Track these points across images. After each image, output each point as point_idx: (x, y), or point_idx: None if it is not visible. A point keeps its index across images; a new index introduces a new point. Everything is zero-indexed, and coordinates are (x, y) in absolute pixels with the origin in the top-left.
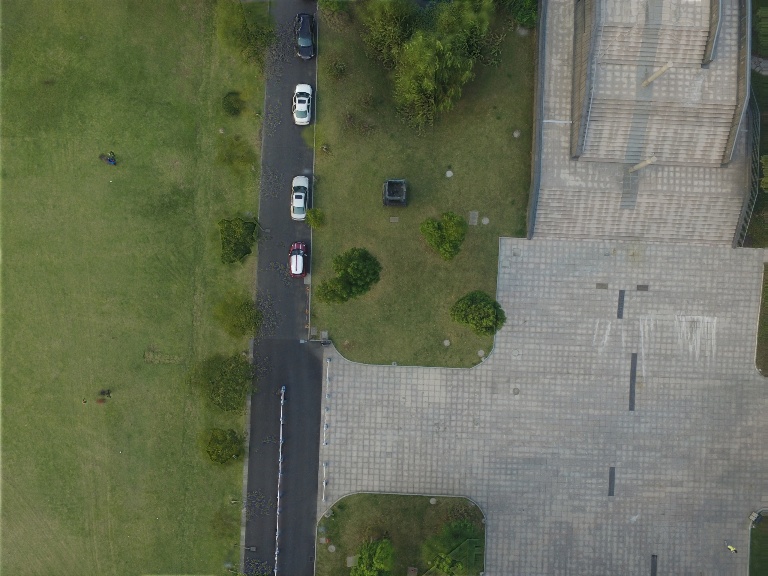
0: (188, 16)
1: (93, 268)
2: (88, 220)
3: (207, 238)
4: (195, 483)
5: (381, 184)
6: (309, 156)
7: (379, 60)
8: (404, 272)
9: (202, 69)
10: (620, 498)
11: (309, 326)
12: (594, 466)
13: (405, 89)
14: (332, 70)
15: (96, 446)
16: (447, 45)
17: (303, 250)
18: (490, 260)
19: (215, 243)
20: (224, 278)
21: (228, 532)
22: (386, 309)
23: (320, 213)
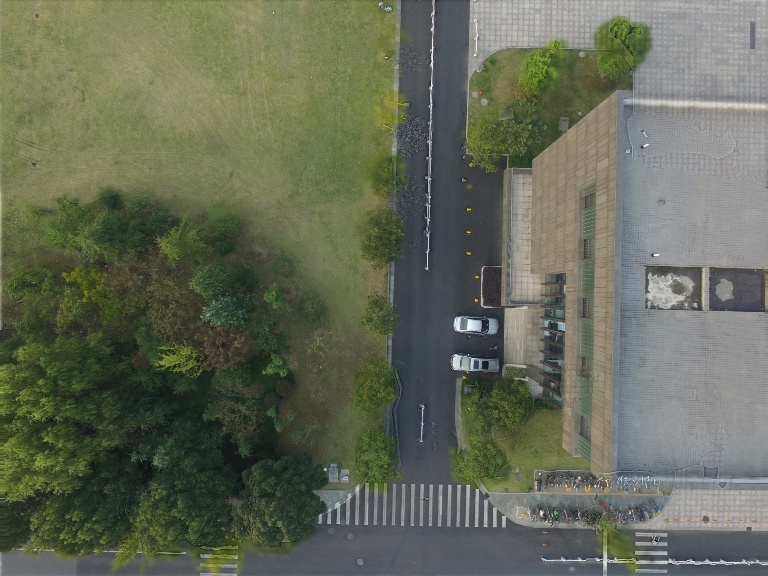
0: None
1: None
2: None
3: None
4: (348, 42)
5: None
6: None
7: None
8: None
9: None
10: (761, 51)
11: None
12: (735, 21)
13: None
14: None
15: (250, 7)
16: None
17: None
18: None
19: None
20: None
21: (381, 89)
22: None
23: None
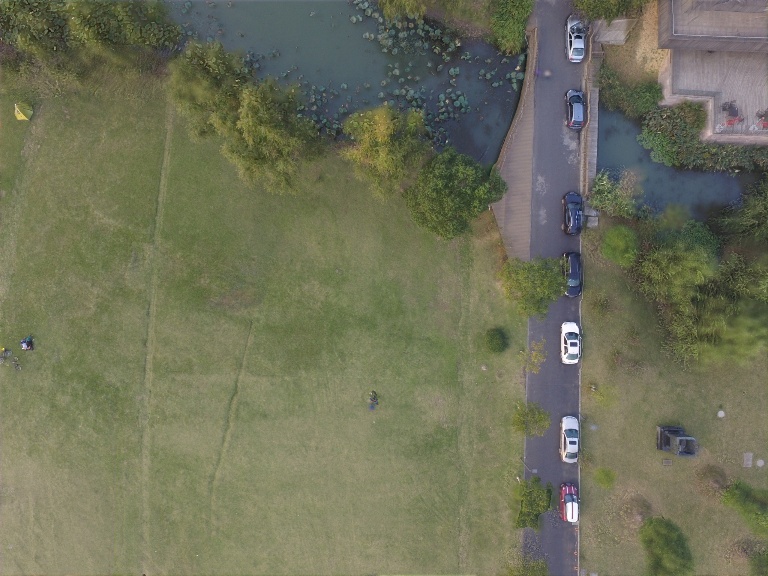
0: (443, 246)
1: (357, 510)
2: (351, 462)
3: (471, 478)
4: None
5: (654, 427)
6: (574, 393)
7: (641, 292)
8: (678, 515)
9: (460, 302)
10: None
11: (579, 568)
12: None
13: (667, 322)
14: (597, 306)
15: None
16: (709, 276)
17: (576, 495)
18: (766, 503)
19: (480, 483)
20: (490, 519)
21: None
22: (659, 552)
23: (588, 453)
